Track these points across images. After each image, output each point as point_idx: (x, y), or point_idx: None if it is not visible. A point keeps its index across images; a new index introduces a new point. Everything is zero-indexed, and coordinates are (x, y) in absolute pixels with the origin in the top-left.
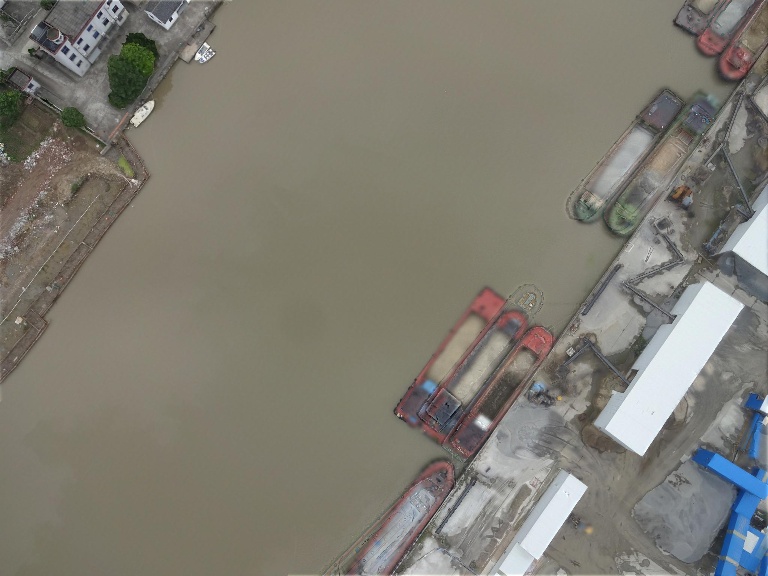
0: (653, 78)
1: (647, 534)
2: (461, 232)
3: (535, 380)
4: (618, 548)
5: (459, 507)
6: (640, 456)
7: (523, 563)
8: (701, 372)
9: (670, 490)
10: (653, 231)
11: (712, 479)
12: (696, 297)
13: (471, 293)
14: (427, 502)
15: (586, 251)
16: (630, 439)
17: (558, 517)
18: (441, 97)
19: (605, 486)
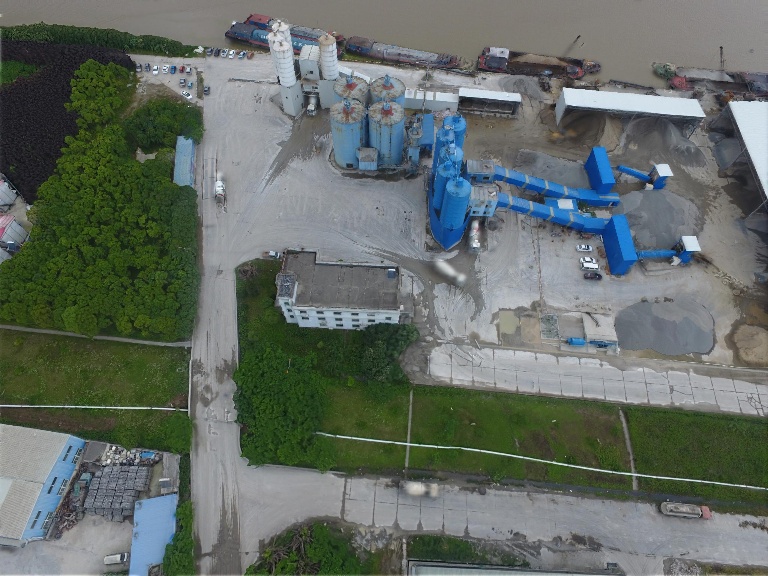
0: (767, 72)
1: (516, 161)
2: (593, 31)
3: (552, 80)
4: (494, 151)
5: (452, 76)
6: (559, 141)
7: (449, 99)
8: (639, 150)
9: (555, 158)
10: (690, 97)
11: (583, 175)
12: (682, 98)
13: (567, 45)
14: (445, 57)
15: (643, 80)
16: (570, 98)
17: (491, 96)
18: (648, 2)
19: (525, 132)
